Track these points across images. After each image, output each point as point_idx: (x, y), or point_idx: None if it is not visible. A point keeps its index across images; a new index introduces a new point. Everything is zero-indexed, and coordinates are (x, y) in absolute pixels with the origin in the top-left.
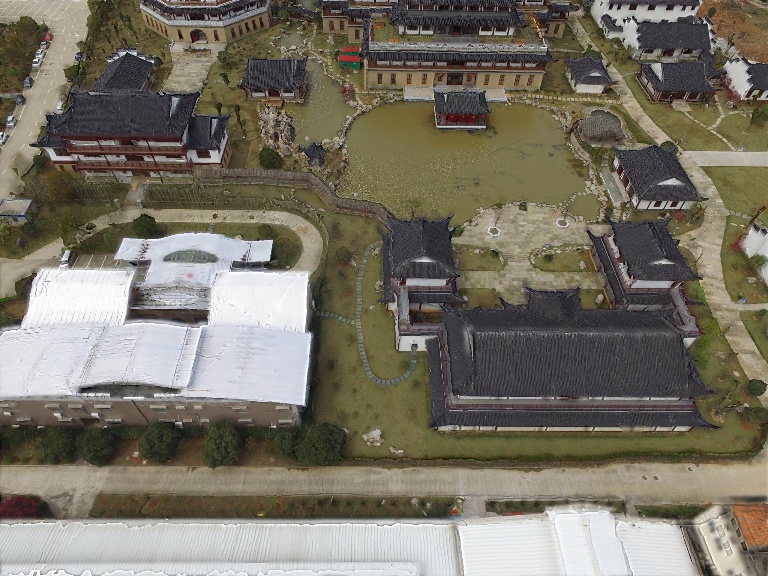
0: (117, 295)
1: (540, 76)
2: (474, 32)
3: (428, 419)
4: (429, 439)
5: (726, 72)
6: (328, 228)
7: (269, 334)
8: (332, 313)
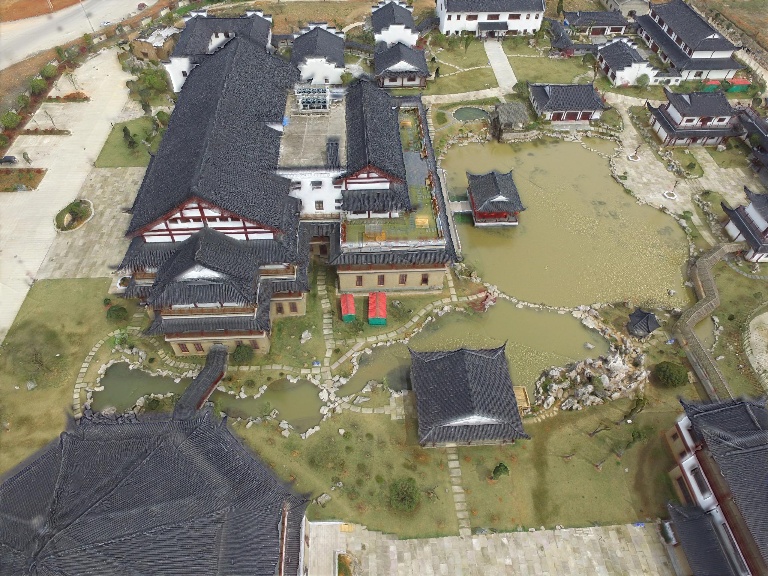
0: None
1: None
2: None
3: None
4: None
5: (385, 42)
6: (763, 301)
7: None
8: None
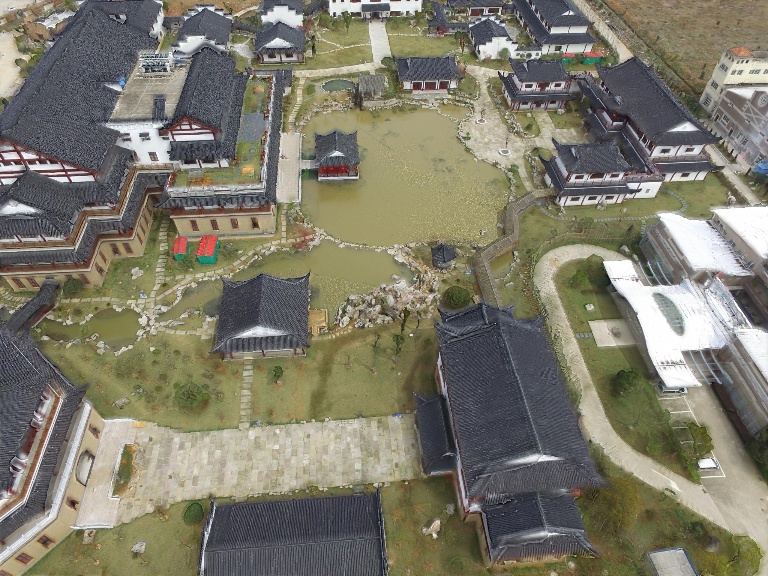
0: (766, 338)
1: None
2: None
3: (697, 184)
4: (710, 184)
5: (271, 22)
6: None
7: (734, 224)
8: (641, 233)
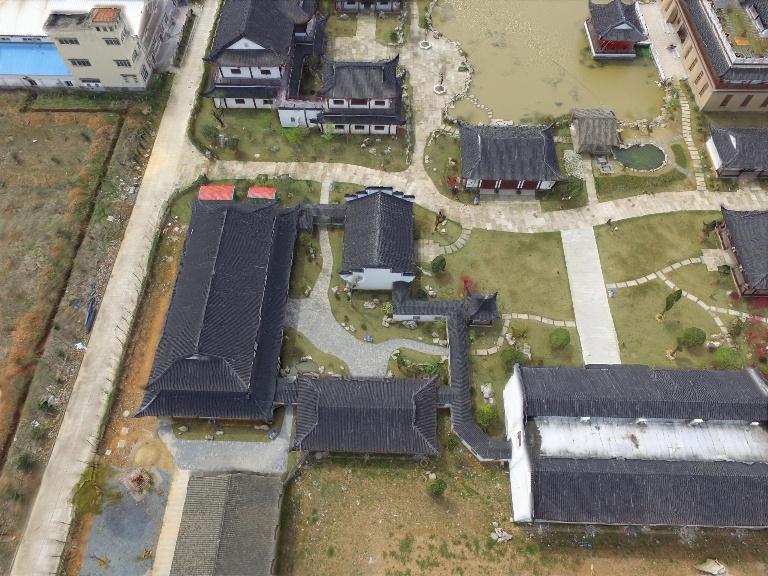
0: None
1: (711, 92)
2: (749, 1)
3: None
4: None
5: None
6: None
7: None
8: None
